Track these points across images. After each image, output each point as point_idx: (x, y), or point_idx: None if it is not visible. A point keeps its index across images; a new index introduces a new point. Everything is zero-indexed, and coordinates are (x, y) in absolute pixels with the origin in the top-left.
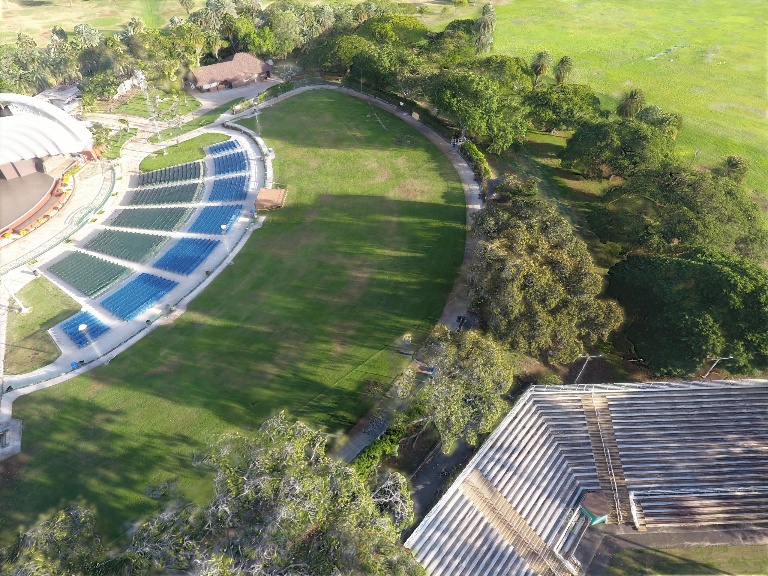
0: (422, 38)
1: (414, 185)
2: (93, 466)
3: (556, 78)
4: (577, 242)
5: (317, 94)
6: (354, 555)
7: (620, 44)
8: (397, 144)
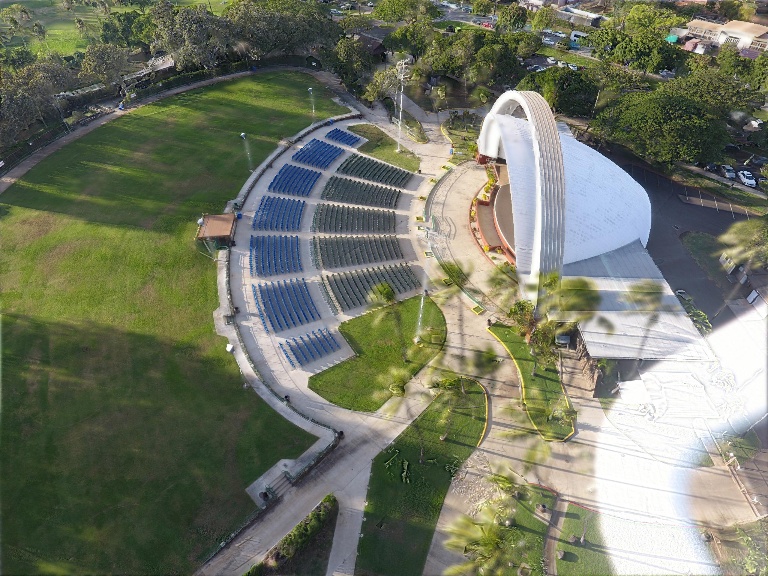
0: None
1: (26, 232)
2: None
3: None
4: None
5: None
6: (164, 1)
7: None
8: None
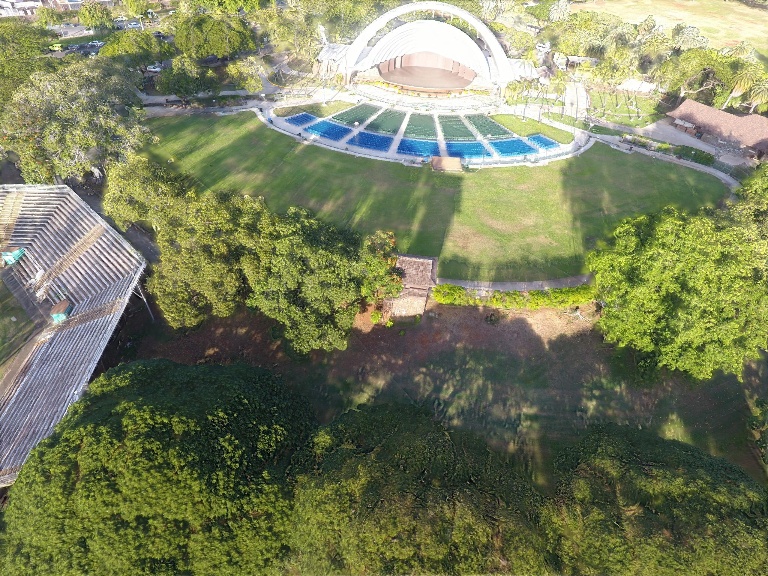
0: None
1: (479, 243)
2: (197, 130)
3: None
4: (311, 324)
5: (705, 181)
6: None
7: None
8: (588, 239)
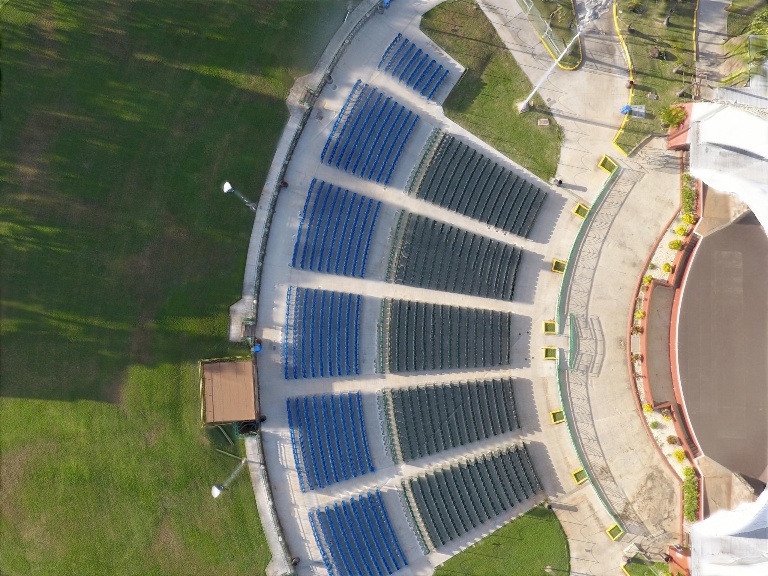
0: None
1: None
2: None
3: None
4: None
5: None
6: None
7: None
8: None
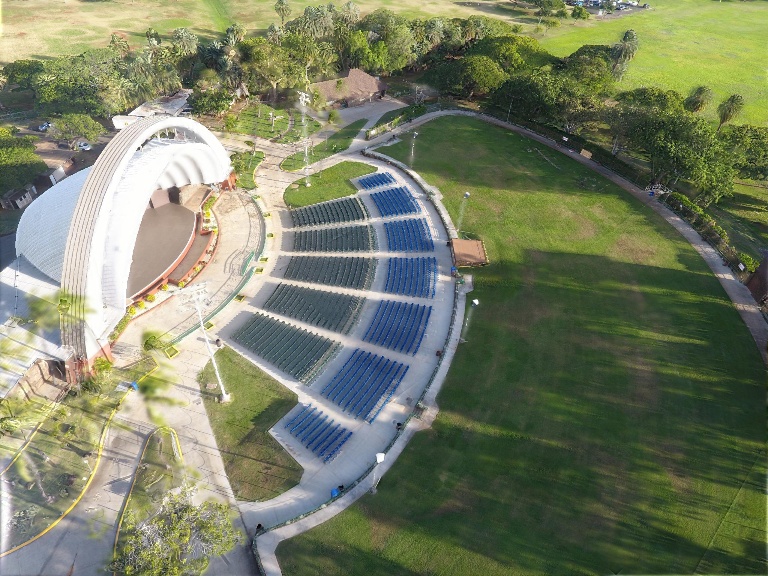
0: (548, 62)
1: (636, 243)
2: None
3: (720, 116)
4: None
5: (457, 121)
6: None
7: (737, 77)
8: (582, 188)
